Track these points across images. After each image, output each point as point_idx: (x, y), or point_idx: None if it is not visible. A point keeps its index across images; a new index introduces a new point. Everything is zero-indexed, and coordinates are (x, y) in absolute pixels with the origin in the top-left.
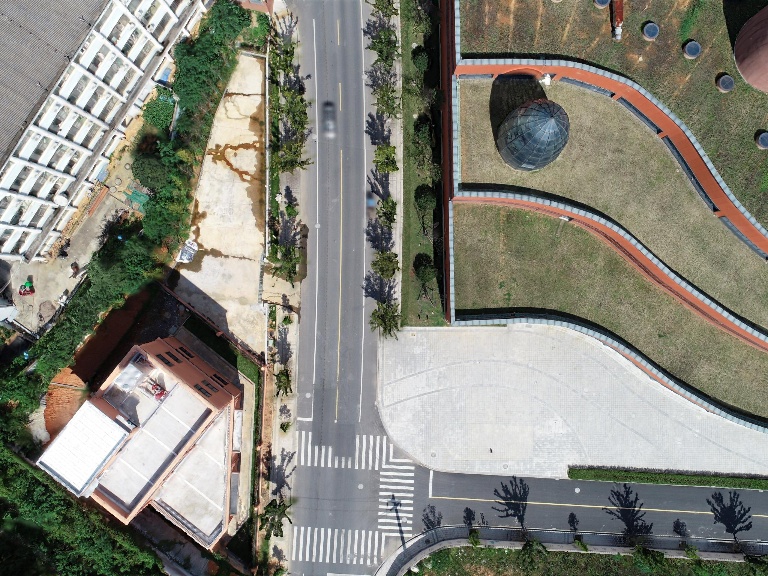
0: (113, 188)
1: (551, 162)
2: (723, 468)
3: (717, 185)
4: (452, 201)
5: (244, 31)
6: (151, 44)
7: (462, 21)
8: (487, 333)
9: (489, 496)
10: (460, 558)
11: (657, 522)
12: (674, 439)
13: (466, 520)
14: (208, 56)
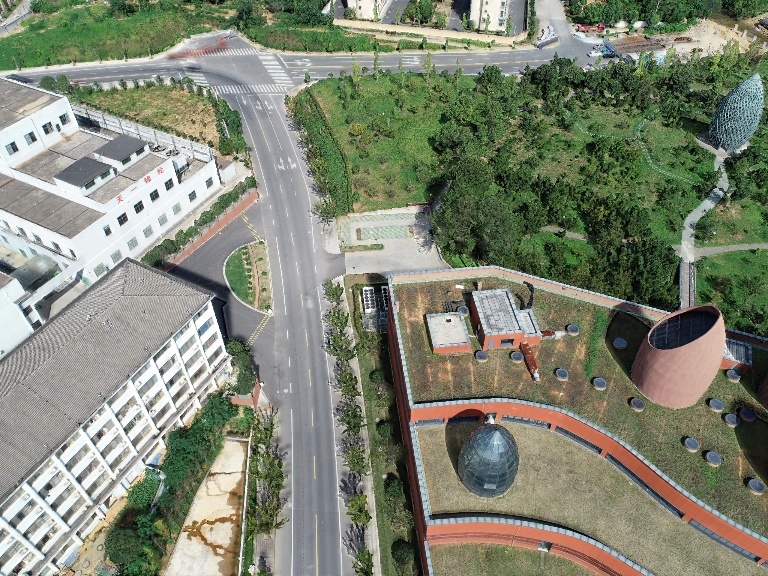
0: (79, 572)
1: (512, 487)
2: None
3: (668, 485)
4: (427, 540)
5: (231, 421)
6: (150, 428)
7: (411, 380)
8: None
9: None
10: None
11: None
12: None
13: None
14: (197, 439)
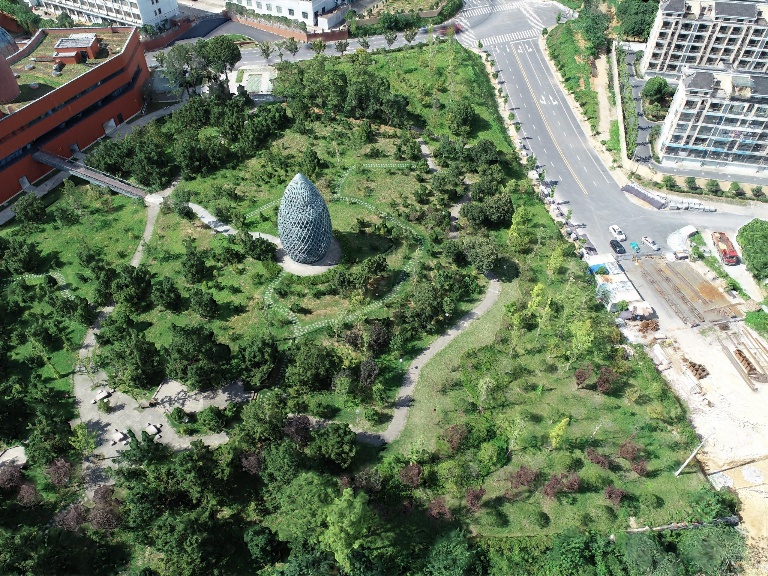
0: None
1: None
2: None
3: None
4: None
5: None
6: None
7: None
8: None
9: None
10: None
11: None
12: None
13: None
14: None
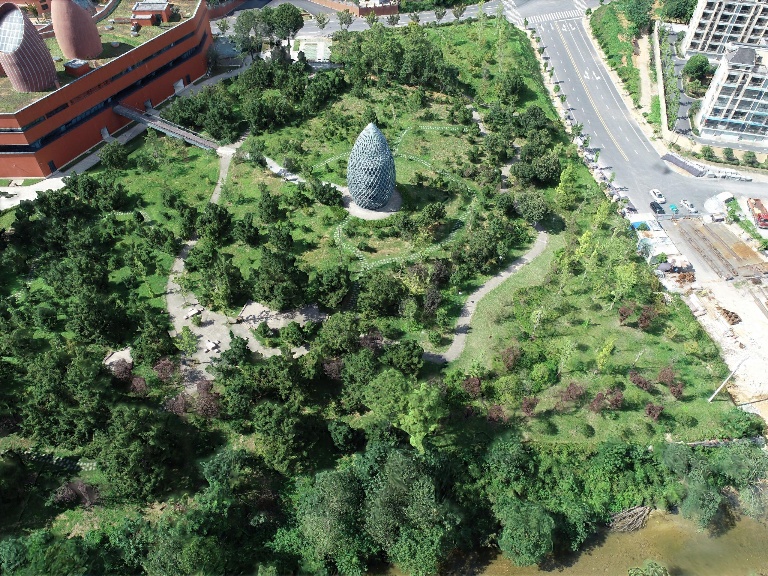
0: None
1: None
2: None
3: None
4: None
5: None
6: None
7: None
8: None
9: None
10: None
11: None
12: None
13: None
14: None
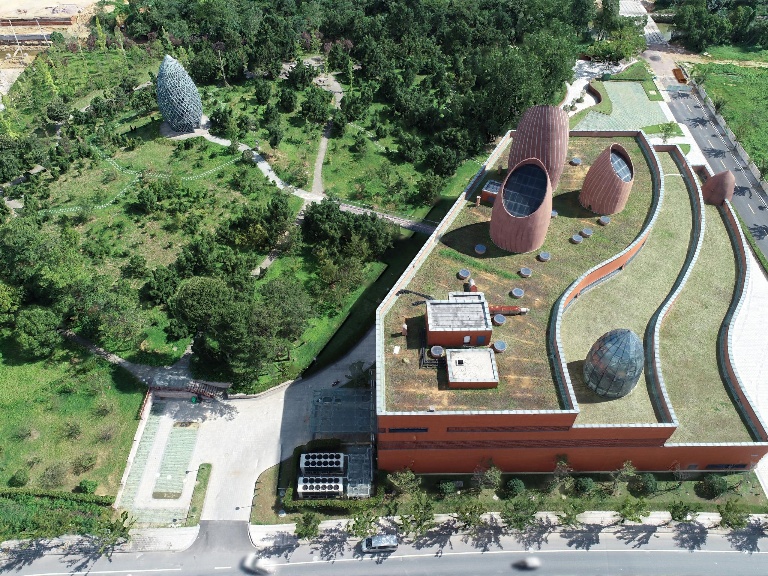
0: None
1: None
2: (767, 285)
3: None
4: (663, 444)
5: None
6: None
7: None
8: None
9: None
10: None
11: None
12: (762, 311)
13: None
14: None
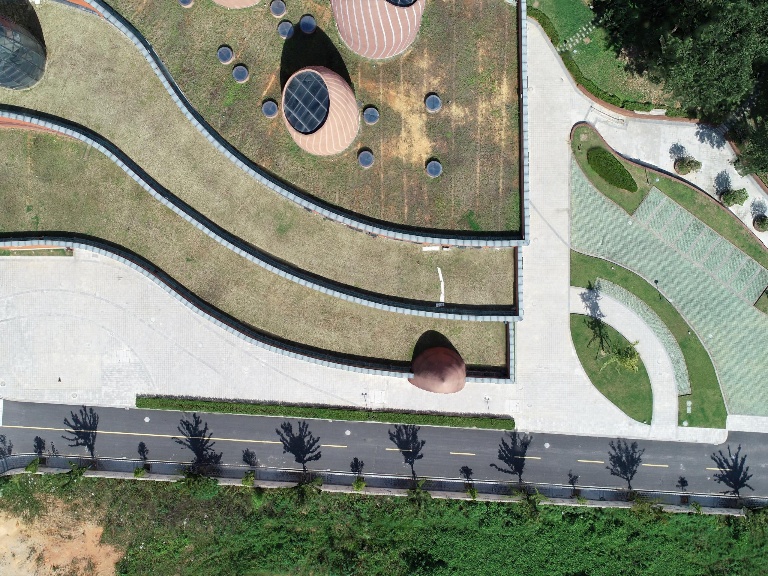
0: None
1: None
2: (291, 398)
3: None
4: None
5: None
6: None
7: None
8: (54, 263)
9: (59, 425)
10: (30, 486)
11: (226, 451)
12: (241, 369)
13: (36, 449)
14: None
